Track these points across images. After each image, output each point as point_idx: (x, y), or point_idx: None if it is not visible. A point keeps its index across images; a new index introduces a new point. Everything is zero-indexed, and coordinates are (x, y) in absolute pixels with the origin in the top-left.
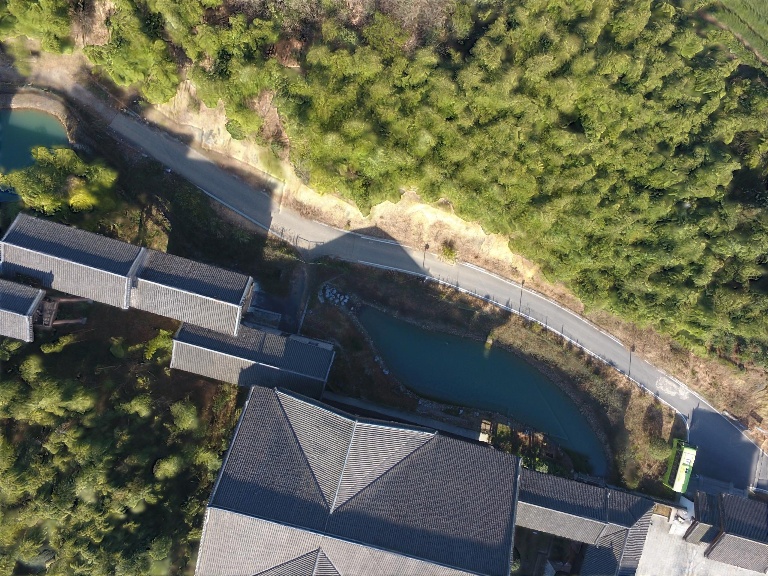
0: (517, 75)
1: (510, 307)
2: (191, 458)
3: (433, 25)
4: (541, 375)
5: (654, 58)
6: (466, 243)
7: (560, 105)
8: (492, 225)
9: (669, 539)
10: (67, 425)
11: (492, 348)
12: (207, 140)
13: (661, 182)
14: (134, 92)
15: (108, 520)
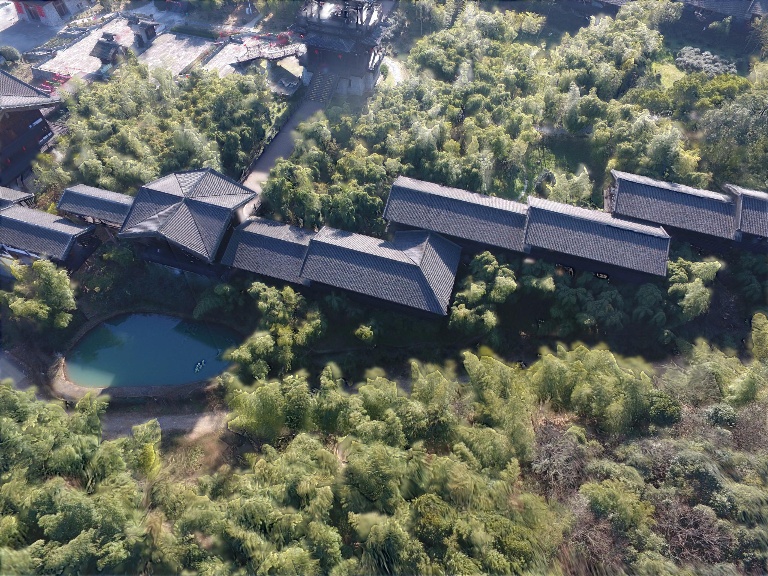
0: None
1: None
2: (55, 158)
3: None
4: None
5: None
6: None
7: None
8: None
9: None
10: (93, 156)
11: None
12: None
13: None
14: None
15: None
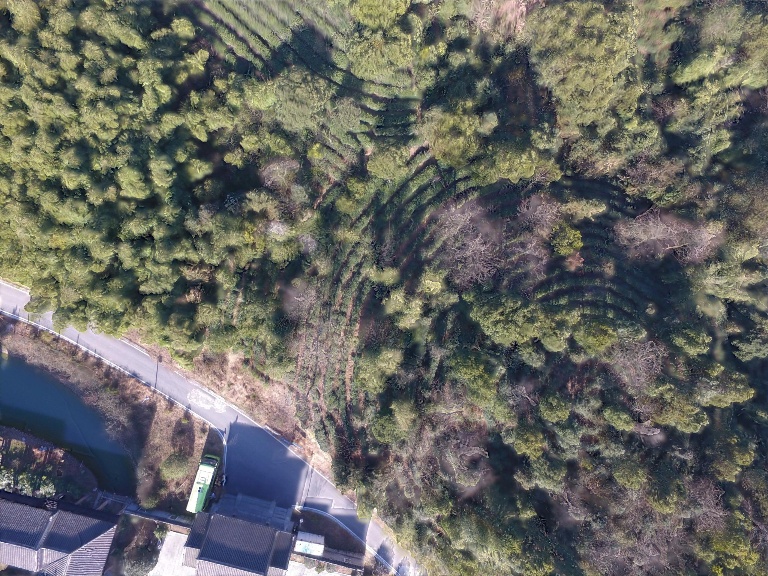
0: None
1: (17, 315)
2: None
3: None
4: (64, 387)
5: (55, 48)
6: None
7: None
8: None
9: None
10: None
11: (10, 358)
12: None
13: (67, 181)
14: None
15: None
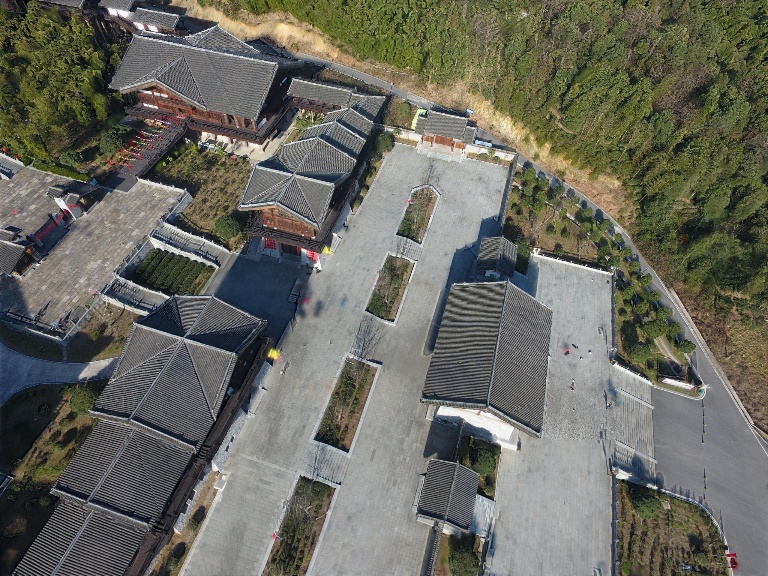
0: None
1: (325, 67)
2: None
3: None
4: None
5: None
6: (304, 45)
7: None
8: (304, 8)
9: (417, 155)
10: None
11: None
12: (188, 13)
13: None
14: (161, 2)
15: (79, 59)
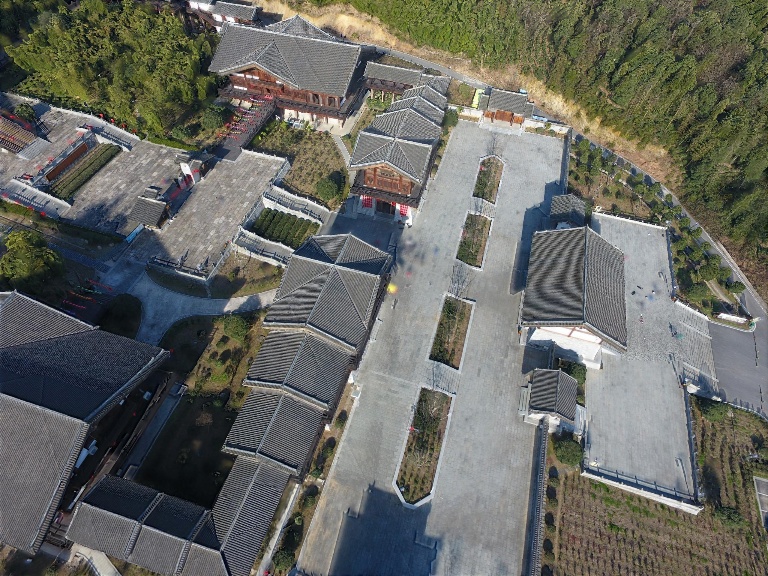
0: None
1: None
2: None
3: None
4: None
5: None
6: (363, 34)
7: None
8: None
9: (480, 130)
10: None
11: None
12: None
13: None
14: None
15: None
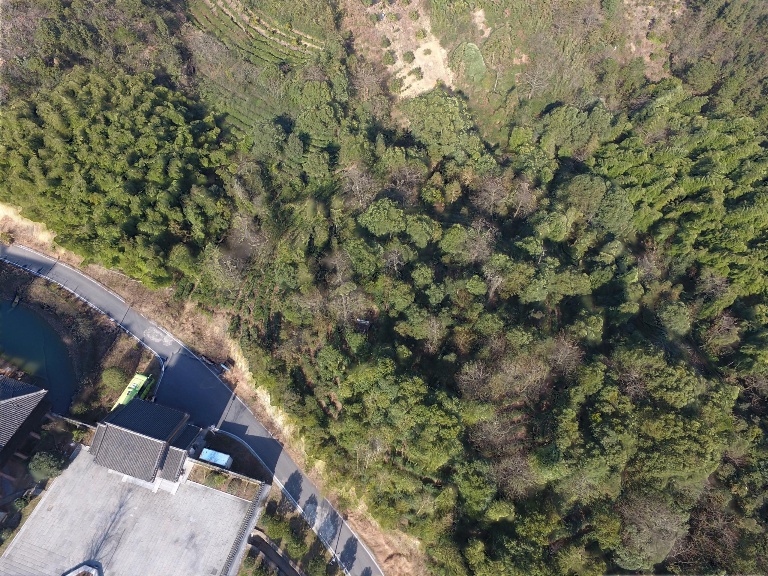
0: (32, 113)
1: (40, 273)
2: None
3: (1, 99)
4: (49, 326)
5: None
6: (23, 231)
7: (54, 126)
8: (0, 191)
9: (106, 479)
10: None
11: (17, 306)
12: None
13: (116, 165)
14: None
15: None
